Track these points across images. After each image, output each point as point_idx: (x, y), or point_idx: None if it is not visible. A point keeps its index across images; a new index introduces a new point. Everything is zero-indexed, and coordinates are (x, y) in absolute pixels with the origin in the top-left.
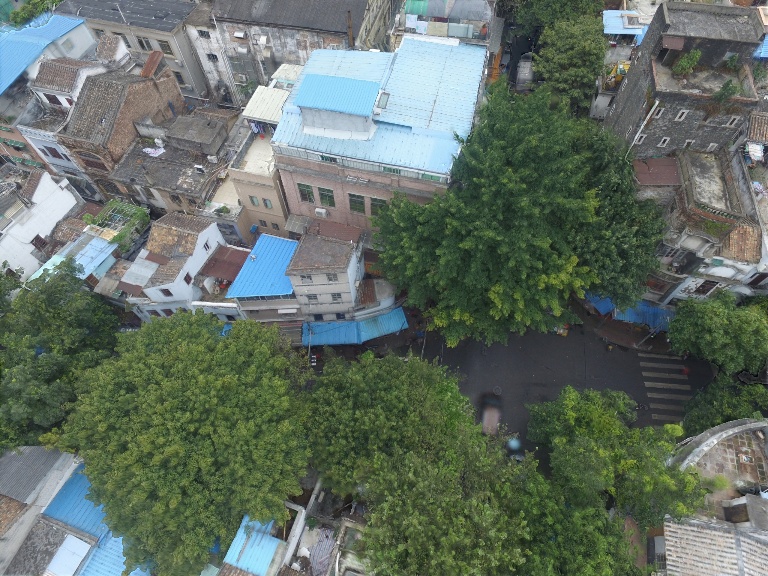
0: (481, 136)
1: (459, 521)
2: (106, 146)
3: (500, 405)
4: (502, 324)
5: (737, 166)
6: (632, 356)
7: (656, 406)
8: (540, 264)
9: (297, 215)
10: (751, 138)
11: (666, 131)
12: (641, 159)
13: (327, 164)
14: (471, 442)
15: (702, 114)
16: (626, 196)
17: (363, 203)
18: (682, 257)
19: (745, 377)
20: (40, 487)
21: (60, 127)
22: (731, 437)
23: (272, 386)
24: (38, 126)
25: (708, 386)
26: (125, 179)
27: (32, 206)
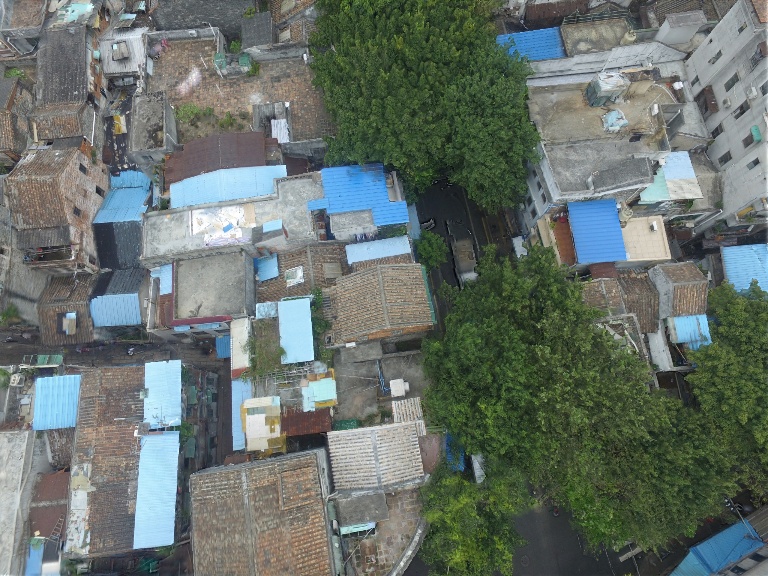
0: None
1: None
2: None
3: None
4: None
5: None
6: None
7: None
8: None
9: None
10: None
11: None
12: None
13: None
14: None
15: None
16: None
17: None
18: None
19: None
20: None
21: None
22: None
23: None
24: None
25: None
26: None
27: None
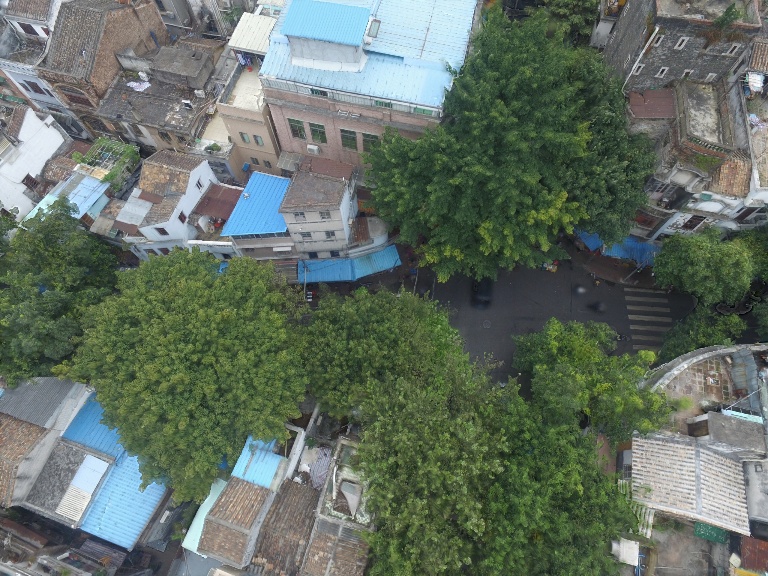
0: (474, 67)
1: (444, 437)
2: (89, 80)
3: (489, 338)
4: (492, 260)
5: (735, 98)
6: (618, 290)
7: (637, 337)
8: (530, 199)
9: (289, 152)
10: (752, 67)
11: (665, 60)
12: (638, 91)
13: (317, 98)
14: (458, 369)
15: (702, 42)
16: (620, 130)
17: (355, 139)
18: (672, 192)
19: (725, 309)
20: (57, 413)
21: (39, 60)
22: (701, 362)
23: (269, 319)
24: (16, 59)
25: (687, 317)
26: (111, 115)
27: (19, 144)
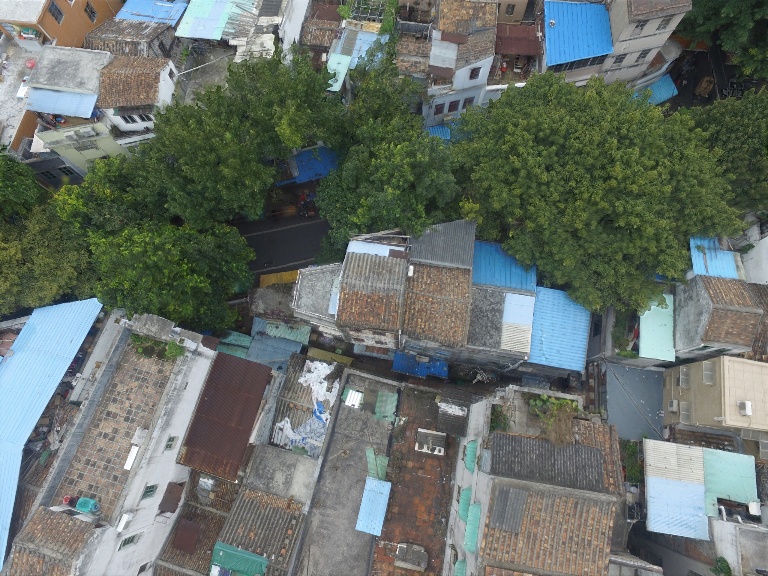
0: None
1: None
2: None
3: None
4: None
5: None
6: None
7: None
8: None
9: None
10: None
11: None
12: None
13: None
14: None
15: None
16: None
17: None
18: None
19: None
20: None
21: None
22: None
23: (682, 121)
24: None
25: None
26: None
27: None
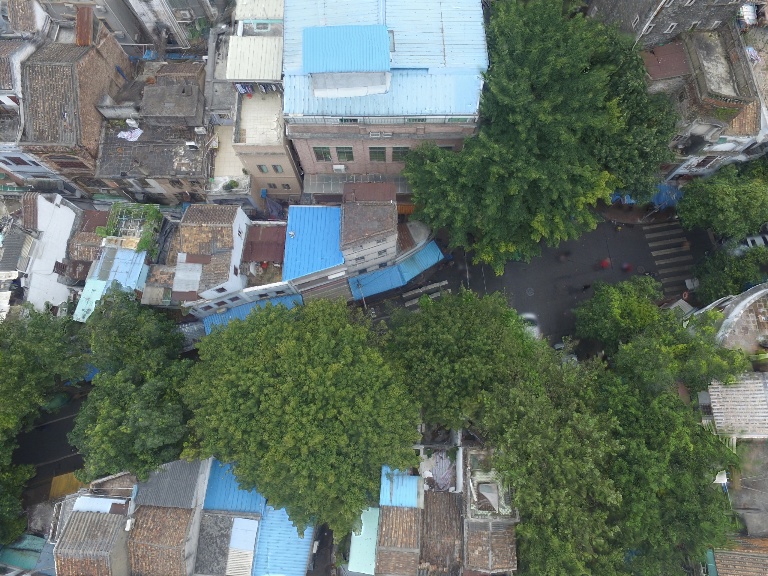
0: (503, 67)
1: (567, 431)
2: (81, 144)
3: (535, 304)
4: None
5: None
6: (638, 231)
7: (664, 271)
8: (580, 190)
9: (312, 174)
10: None
11: (674, 17)
12: (648, 49)
13: (347, 125)
14: None
15: None
16: (640, 95)
17: (384, 153)
18: (687, 139)
19: None
20: (196, 492)
21: (18, 133)
22: None
23: (371, 360)
24: None
25: (715, 252)
26: (114, 175)
27: (40, 236)
